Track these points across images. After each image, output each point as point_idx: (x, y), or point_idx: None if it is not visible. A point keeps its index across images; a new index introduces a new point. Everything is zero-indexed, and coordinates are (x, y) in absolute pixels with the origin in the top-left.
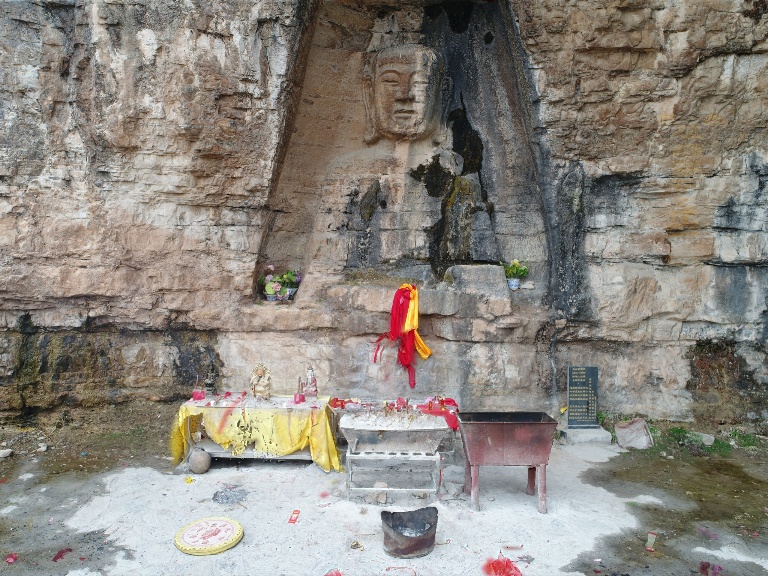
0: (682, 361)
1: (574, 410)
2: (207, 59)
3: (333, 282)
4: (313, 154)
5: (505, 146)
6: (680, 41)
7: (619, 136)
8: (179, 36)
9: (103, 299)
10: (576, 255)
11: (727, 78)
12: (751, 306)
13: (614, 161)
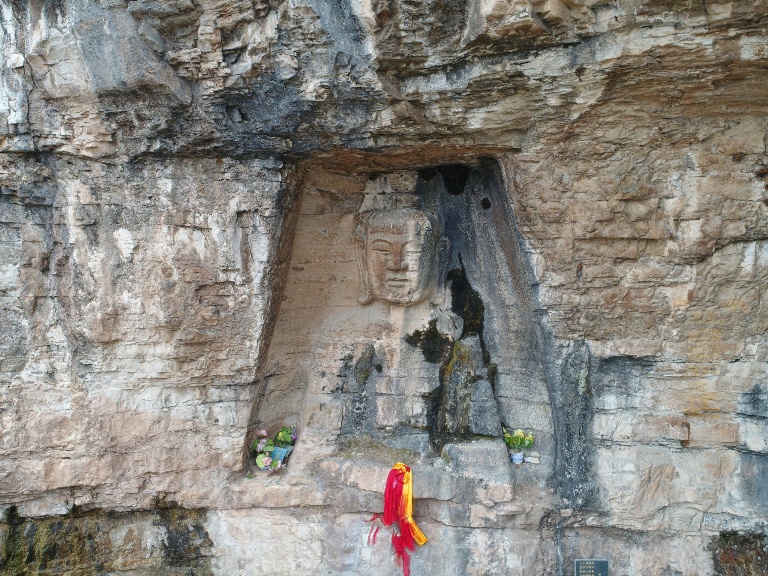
0: (704, 553)
1: None
2: (185, 253)
3: (325, 455)
4: (306, 316)
5: (507, 310)
6: (693, 230)
7: (628, 319)
8: (156, 233)
9: (88, 487)
10: (583, 438)
11: (748, 265)
12: None
13: (623, 343)
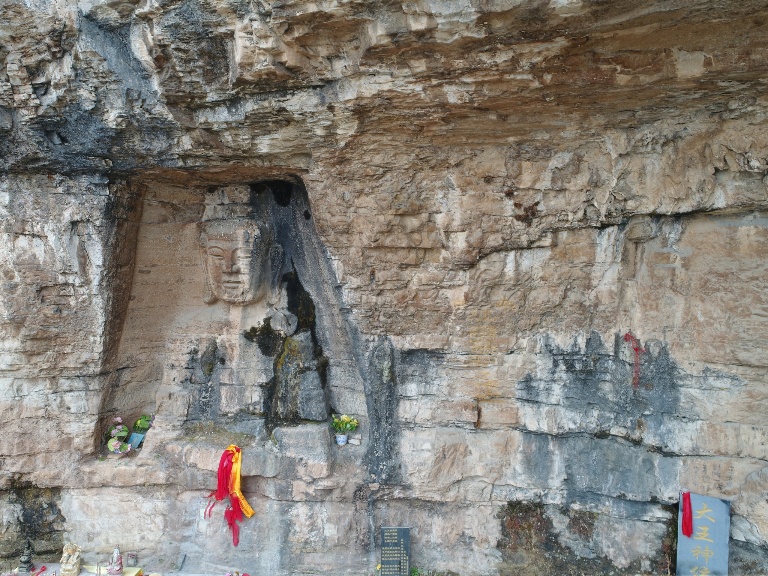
0: (494, 521)
1: (386, 569)
2: (25, 258)
3: (170, 439)
4: (156, 314)
5: (332, 309)
6: (460, 240)
7: (419, 317)
8: None
9: None
10: (390, 421)
11: (510, 271)
12: (553, 474)
13: (417, 338)
